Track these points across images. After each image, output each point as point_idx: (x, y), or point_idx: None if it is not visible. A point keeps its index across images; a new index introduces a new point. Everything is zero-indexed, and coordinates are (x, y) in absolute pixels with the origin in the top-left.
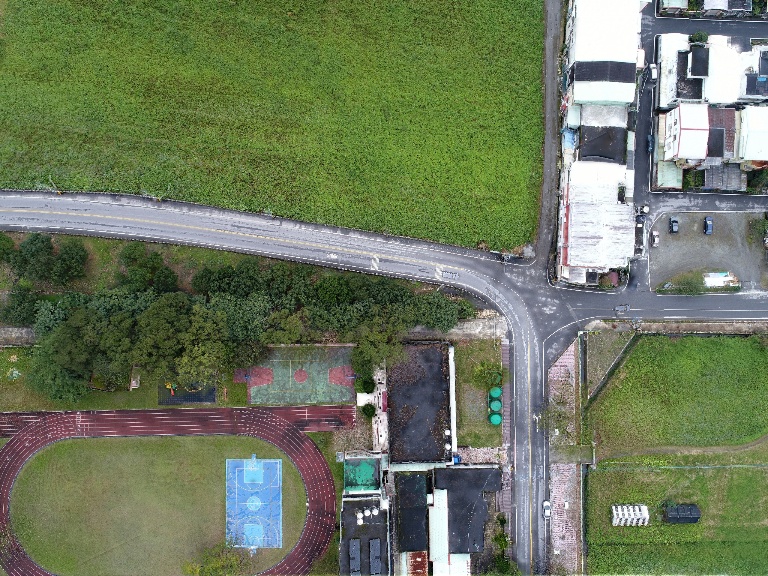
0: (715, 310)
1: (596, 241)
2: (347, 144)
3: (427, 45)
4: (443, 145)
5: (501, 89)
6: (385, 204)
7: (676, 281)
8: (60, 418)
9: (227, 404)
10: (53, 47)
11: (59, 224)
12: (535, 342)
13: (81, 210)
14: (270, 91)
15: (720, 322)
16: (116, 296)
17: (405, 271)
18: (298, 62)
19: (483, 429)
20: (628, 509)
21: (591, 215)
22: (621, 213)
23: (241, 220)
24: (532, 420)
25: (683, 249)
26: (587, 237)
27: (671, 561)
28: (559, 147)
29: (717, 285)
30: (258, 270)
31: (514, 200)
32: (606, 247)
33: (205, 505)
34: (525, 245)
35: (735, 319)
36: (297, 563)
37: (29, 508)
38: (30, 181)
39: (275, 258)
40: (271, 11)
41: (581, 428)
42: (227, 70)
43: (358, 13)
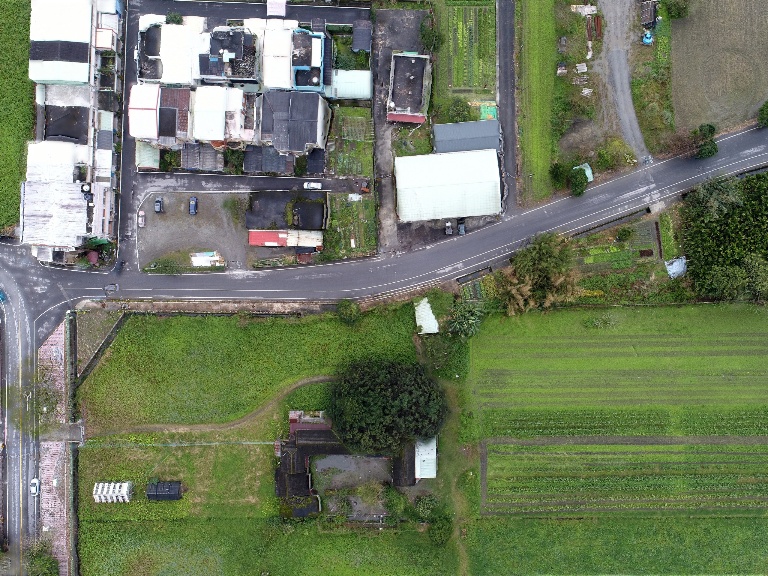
0: (202, 289)
1: (46, 220)
2: None
3: None
4: None
5: None
6: None
7: (163, 261)
8: None
9: None
10: None
11: None
12: (26, 321)
13: None
14: None
15: (206, 301)
16: None
17: None
18: None
19: None
20: (109, 486)
21: (42, 194)
22: (72, 192)
23: None
24: (23, 398)
25: (171, 229)
26: (38, 216)
27: (157, 537)
28: None
29: (203, 265)
30: None
31: (5, 180)
32: (55, 226)
33: None
34: (16, 225)
35: (221, 298)
36: None
37: None
38: None
39: None
40: None
41: (68, 406)
42: None
43: None
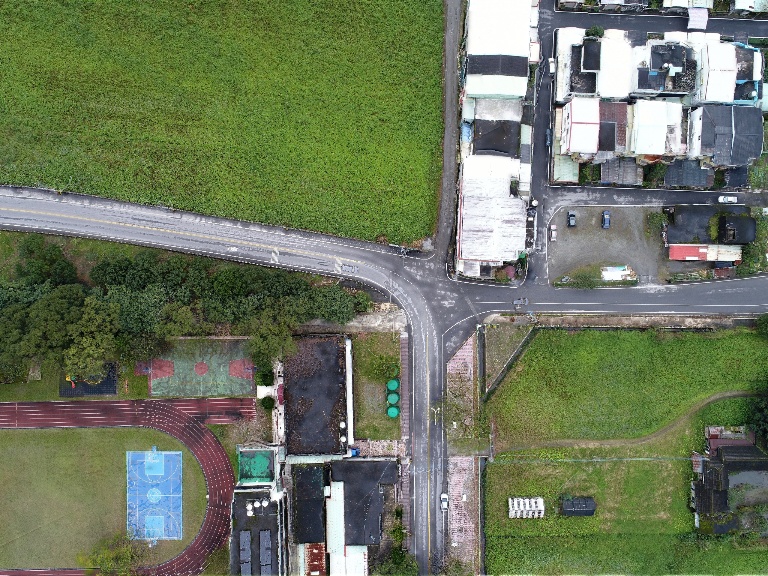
0: (613, 304)
1: (487, 234)
2: (248, 137)
3: (327, 39)
4: (343, 139)
5: (401, 83)
6: (285, 197)
7: (574, 275)
8: None
9: (128, 396)
10: None
11: None
12: (434, 335)
13: None
14: (171, 84)
15: (617, 316)
16: (13, 288)
17: (305, 264)
18: (199, 55)
19: (382, 422)
20: (524, 502)
21: (482, 208)
22: (512, 207)
23: (142, 213)
24: (431, 413)
25: (581, 243)
26: (478, 230)
27: (568, 553)
28: (458, 141)
29: (615, 279)
30: (154, 263)
31: (413, 194)
32: (497, 240)
33: (106, 497)
34: (424, 239)
35: (632, 313)
36: (197, 555)
37: None
38: None
39: (176, 251)
40: (172, 4)
41: (479, 421)
42: (128, 63)
43: (259, 6)
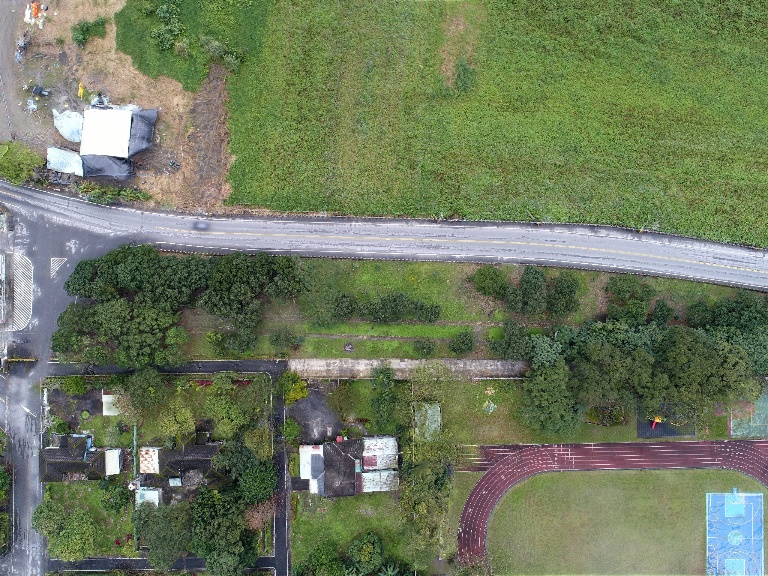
0: None
1: None
2: None
3: None
4: None
5: None
6: None
7: None
8: (537, 451)
9: (707, 438)
10: (528, 77)
11: (536, 255)
12: None
13: (559, 241)
14: (751, 122)
15: None
16: (619, 330)
17: None
18: None
19: None
20: None
21: None
22: None
23: (723, 252)
24: None
25: None
26: None
27: None
28: None
29: None
30: (763, 304)
31: None
32: None
33: (685, 539)
34: None
35: None
36: None
37: (506, 542)
38: (507, 212)
39: (757, 290)
40: (752, 41)
41: None
42: (707, 101)
43: None
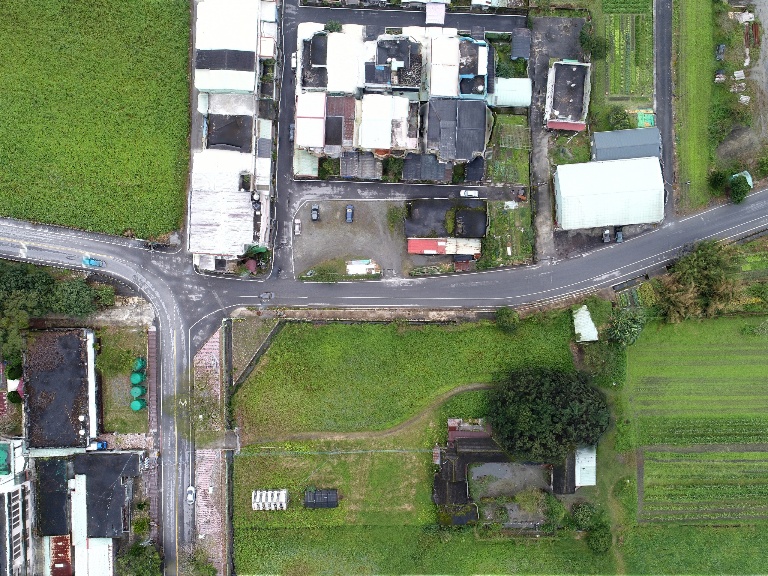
0: (357, 297)
1: (214, 228)
2: None
3: (75, 34)
4: (91, 133)
5: (148, 78)
6: (34, 192)
7: (319, 269)
8: None
9: None
10: None
11: None
12: (181, 329)
13: None
14: None
15: (362, 309)
16: None
17: (53, 259)
18: None
19: (129, 415)
20: (267, 494)
21: (209, 203)
22: (239, 201)
23: None
24: (178, 406)
25: (326, 237)
26: (205, 224)
27: (313, 545)
28: None
29: (359, 273)
30: None
31: (160, 188)
32: (223, 234)
33: None
34: (171, 233)
35: (377, 306)
36: None
37: None
38: None
39: None
40: None
41: (224, 414)
42: None
43: (6, 1)
